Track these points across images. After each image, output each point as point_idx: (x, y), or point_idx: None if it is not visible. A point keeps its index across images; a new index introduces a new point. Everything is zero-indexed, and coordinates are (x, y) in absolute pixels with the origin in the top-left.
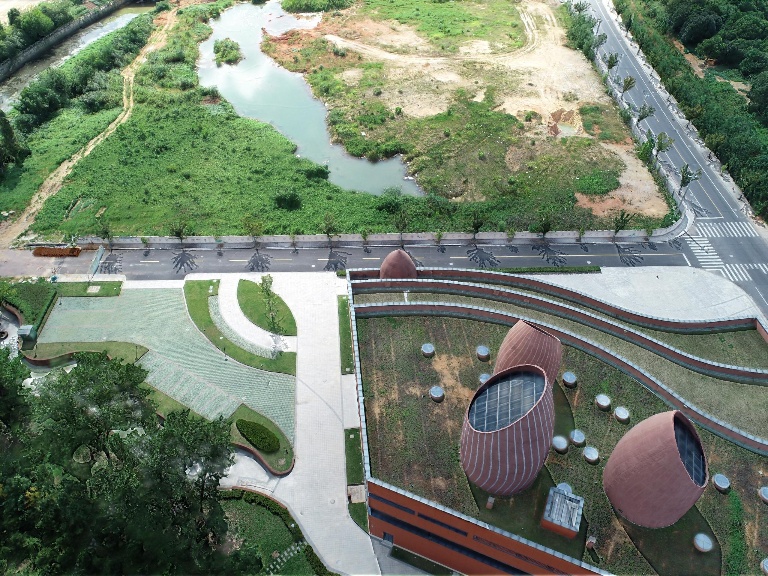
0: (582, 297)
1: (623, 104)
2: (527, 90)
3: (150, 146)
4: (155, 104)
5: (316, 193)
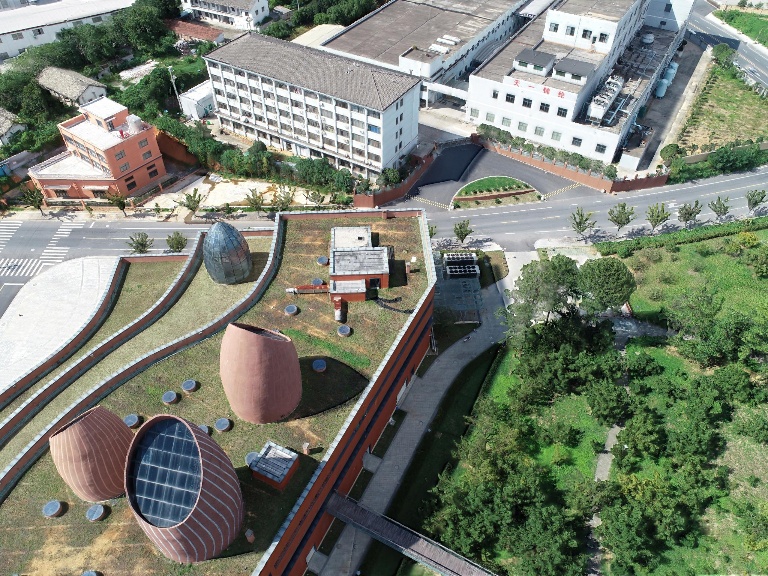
0: (15, 387)
1: None
2: None
3: None
4: None
5: None
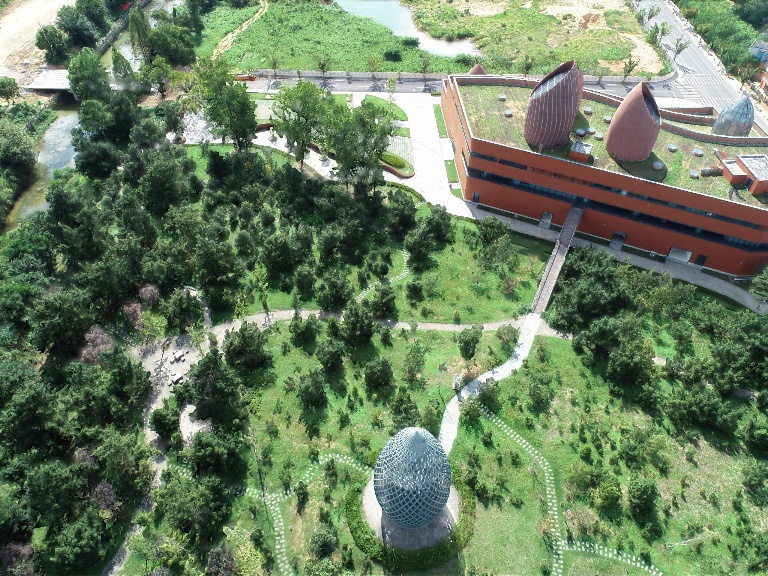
0: None
1: (638, 9)
2: (564, 2)
3: (288, 26)
4: (285, 3)
5: (411, 54)
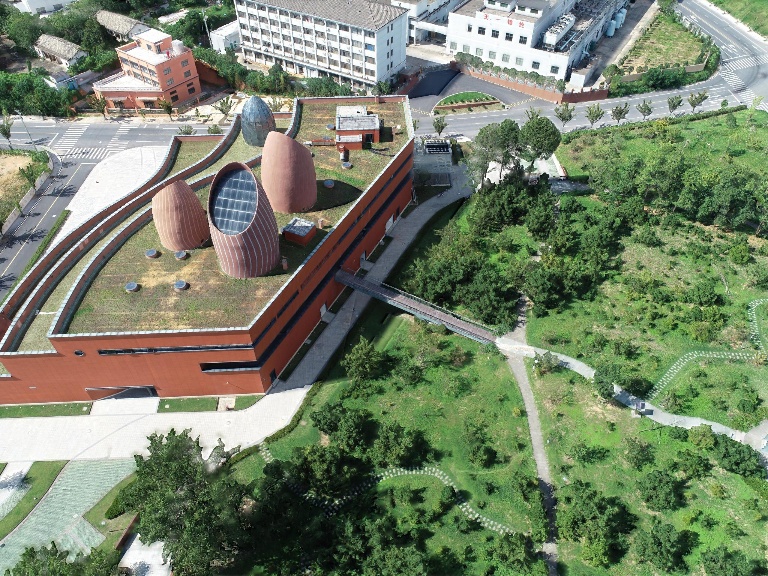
0: (106, 211)
1: None
2: None
3: None
4: None
5: None
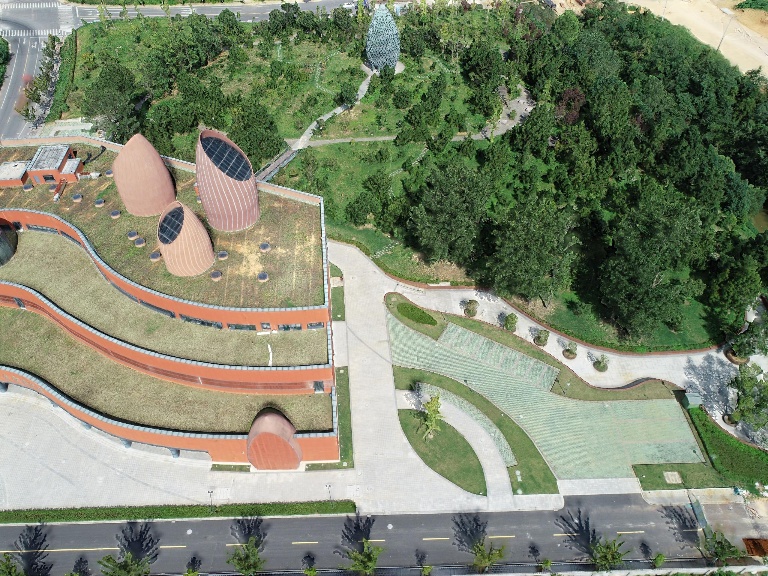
0: None
1: None
2: None
3: None
4: None
5: None
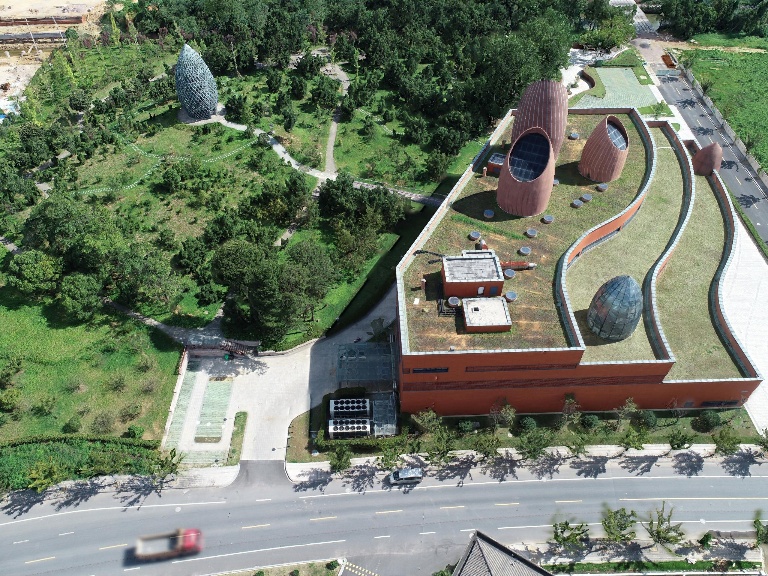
0: None
1: None
2: None
3: None
4: None
5: None
